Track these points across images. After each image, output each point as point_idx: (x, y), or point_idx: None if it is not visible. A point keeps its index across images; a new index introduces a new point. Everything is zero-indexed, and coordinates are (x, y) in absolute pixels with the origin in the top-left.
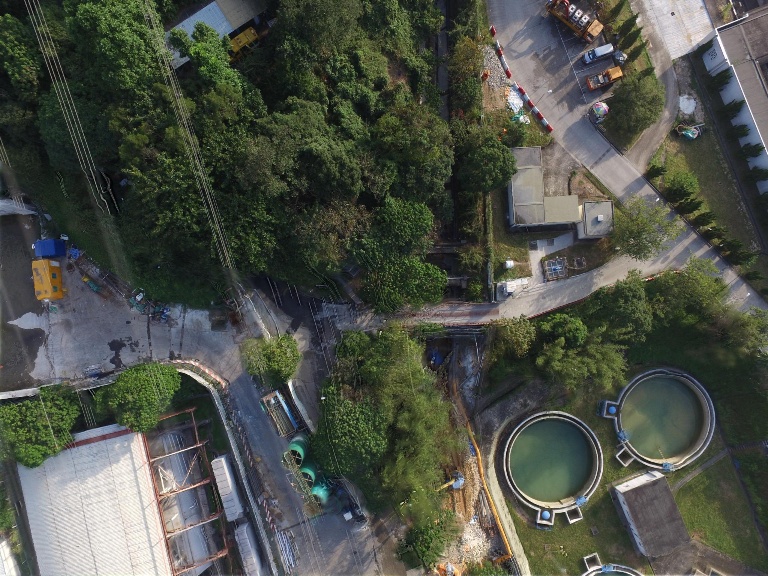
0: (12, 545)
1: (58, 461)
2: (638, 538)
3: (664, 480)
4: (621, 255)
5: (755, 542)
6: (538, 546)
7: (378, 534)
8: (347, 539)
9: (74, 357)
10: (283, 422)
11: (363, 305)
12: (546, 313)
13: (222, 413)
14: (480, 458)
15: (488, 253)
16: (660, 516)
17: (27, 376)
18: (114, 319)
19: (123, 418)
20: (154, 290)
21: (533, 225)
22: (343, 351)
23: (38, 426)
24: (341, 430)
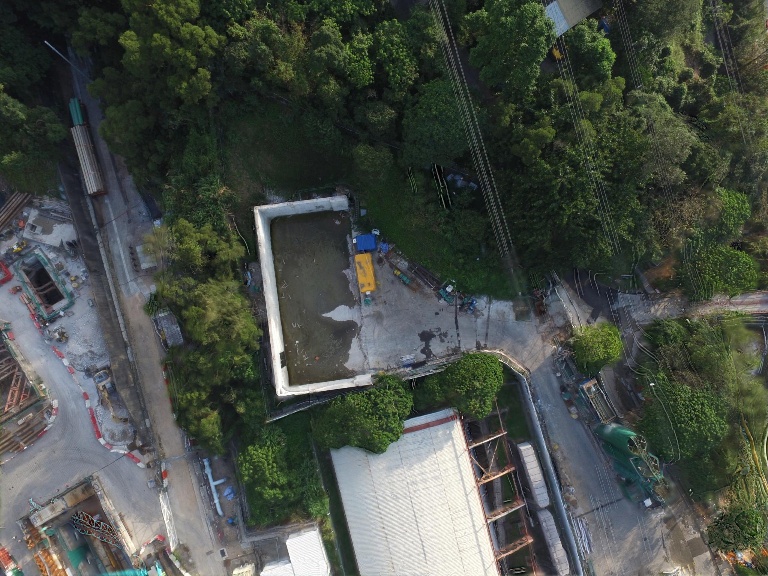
0: (324, 532)
1: None
2: None
3: None
4: None
5: None
6: None
7: (666, 521)
8: (638, 526)
9: (387, 348)
10: (602, 409)
11: (657, 294)
12: None
13: (532, 401)
14: (754, 445)
15: None
16: None
17: (342, 367)
18: (423, 311)
19: (470, 405)
20: (473, 281)
21: None
22: (664, 338)
23: (389, 413)
24: (687, 414)
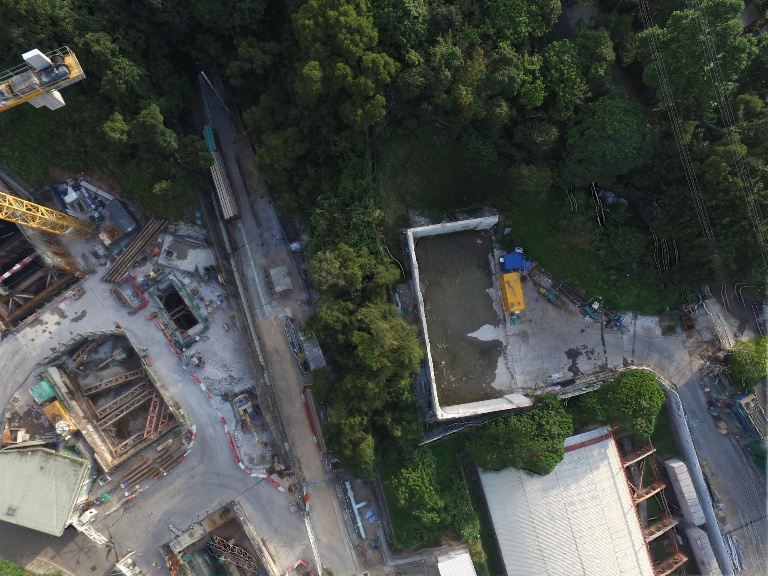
0: (473, 554)
1: None
2: None
3: None
4: None
5: None
6: None
7: None
8: None
9: (534, 367)
10: (760, 424)
11: None
12: None
13: None
14: None
15: None
16: None
17: (489, 387)
18: (569, 328)
19: (636, 424)
20: (624, 298)
21: None
22: None
23: (555, 434)
24: None
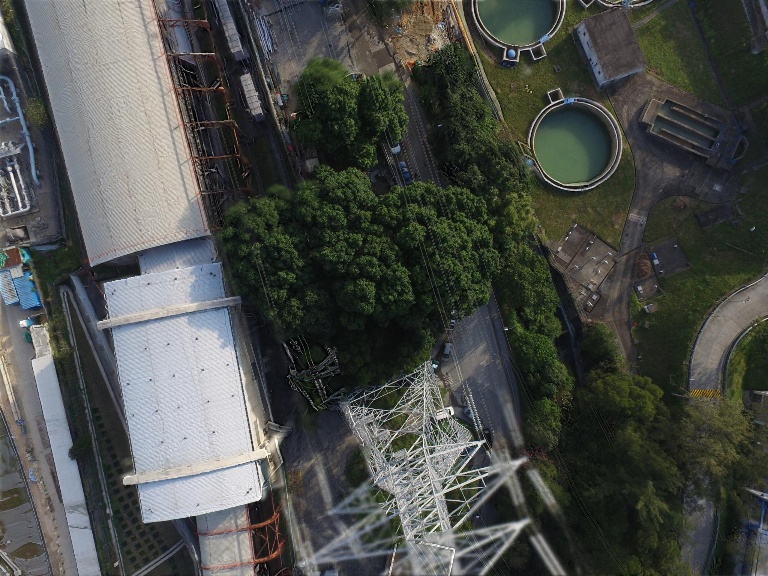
0: (5, 14)
1: None
2: (597, 65)
3: (622, 9)
4: None
5: (707, 76)
6: (504, 84)
7: (351, 30)
8: (322, 30)
9: None
10: None
11: None
12: None
13: None
14: None
15: None
16: (618, 40)
17: None
18: None
19: None
20: None
21: None
22: None
23: None
24: None
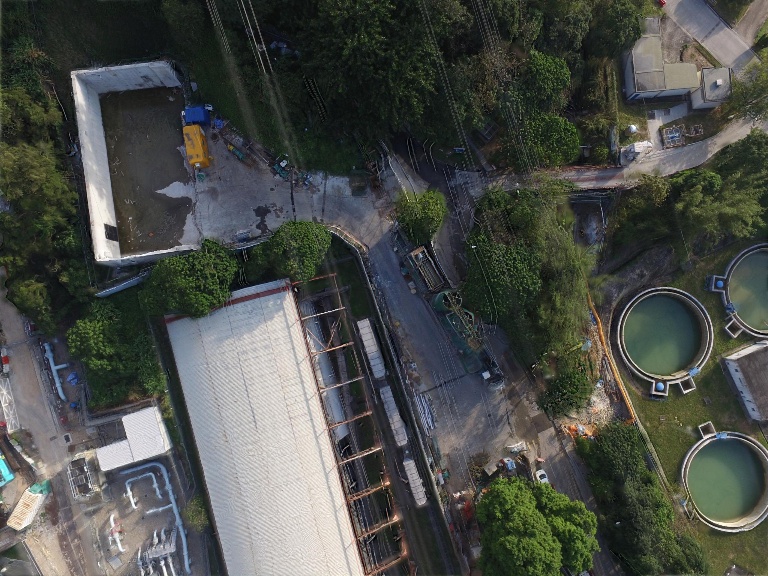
0: (163, 410)
1: (214, 320)
2: (752, 403)
3: None
4: (738, 119)
5: None
6: (653, 417)
7: (511, 397)
8: (482, 402)
9: (221, 223)
10: (431, 276)
11: (494, 171)
12: (670, 175)
13: (367, 274)
14: (601, 327)
15: (614, 117)
16: None
17: (176, 243)
18: (258, 186)
19: (288, 265)
20: (302, 152)
21: (650, 96)
22: (488, 204)
23: (206, 274)
24: (499, 269)
